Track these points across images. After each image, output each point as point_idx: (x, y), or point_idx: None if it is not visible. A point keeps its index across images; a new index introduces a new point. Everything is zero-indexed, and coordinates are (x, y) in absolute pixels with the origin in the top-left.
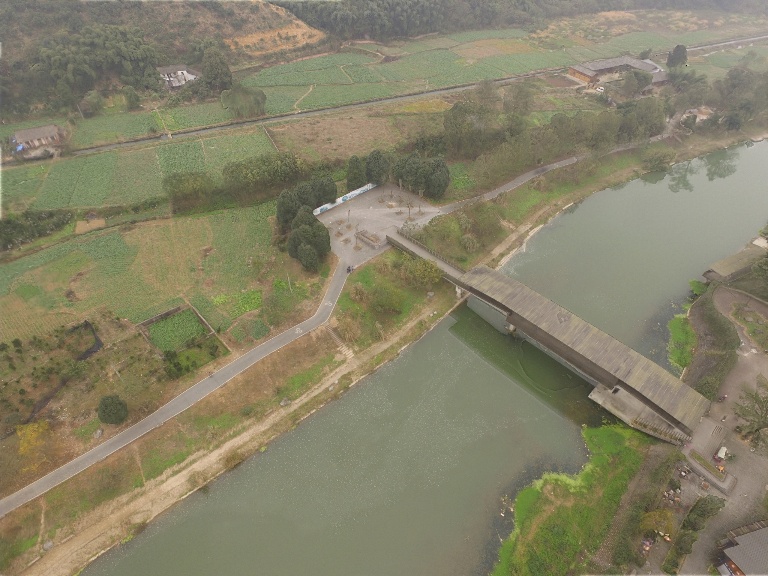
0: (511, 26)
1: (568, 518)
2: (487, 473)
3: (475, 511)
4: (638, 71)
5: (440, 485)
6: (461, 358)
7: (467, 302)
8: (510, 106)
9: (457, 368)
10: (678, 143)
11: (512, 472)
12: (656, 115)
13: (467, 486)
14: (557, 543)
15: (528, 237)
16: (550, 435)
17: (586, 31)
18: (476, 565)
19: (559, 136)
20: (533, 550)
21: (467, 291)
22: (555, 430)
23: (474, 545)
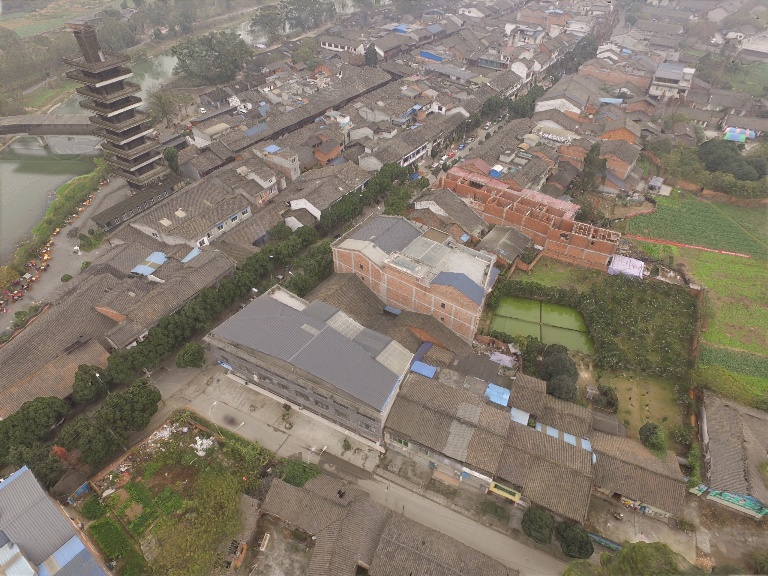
0: (11, 11)
1: (86, 183)
2: (38, 190)
3: (34, 202)
4: (106, 9)
5: (8, 203)
6: (10, 165)
7: (10, 147)
8: (5, 46)
9: (8, 168)
10: (153, 46)
11: (53, 184)
12: (118, 28)
13: (26, 197)
14: (80, 190)
15: (50, 111)
16: (75, 168)
17: (83, 4)
18: (37, 213)
19: (54, 55)
20: (65, 195)
21: (0, 136)
22: (78, 165)
23: (35, 209)
